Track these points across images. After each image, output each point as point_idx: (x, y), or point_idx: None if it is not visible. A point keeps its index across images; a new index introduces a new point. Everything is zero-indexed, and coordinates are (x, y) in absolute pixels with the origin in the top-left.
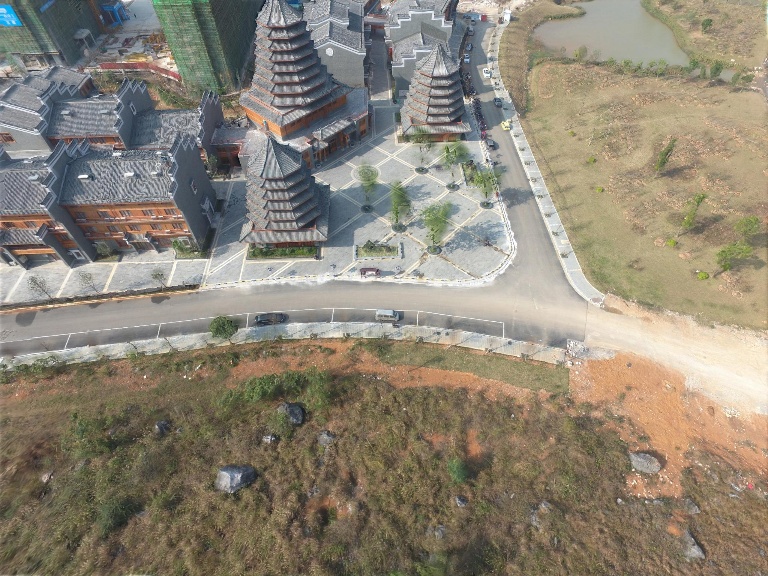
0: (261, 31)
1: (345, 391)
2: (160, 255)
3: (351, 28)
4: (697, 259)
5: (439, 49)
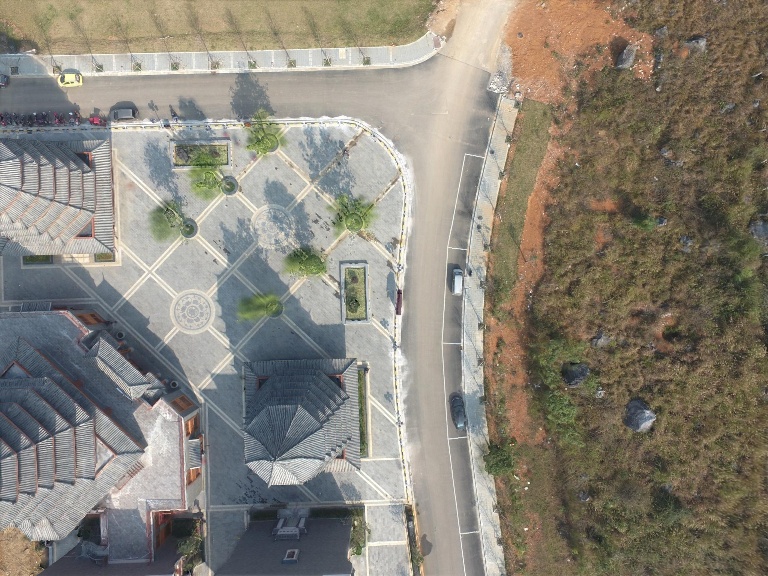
0: None
1: (552, 325)
2: (358, 568)
3: None
4: None
5: None
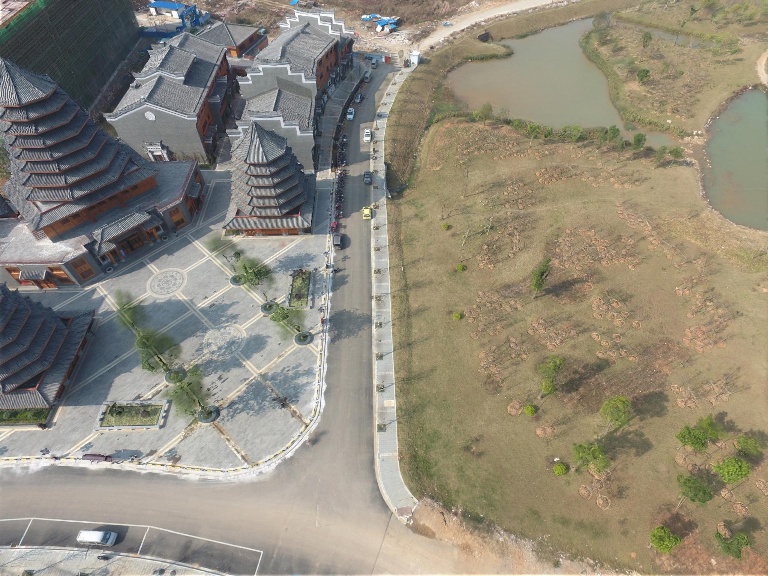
0: None
1: None
2: None
3: (192, 82)
4: (560, 437)
5: (253, 129)
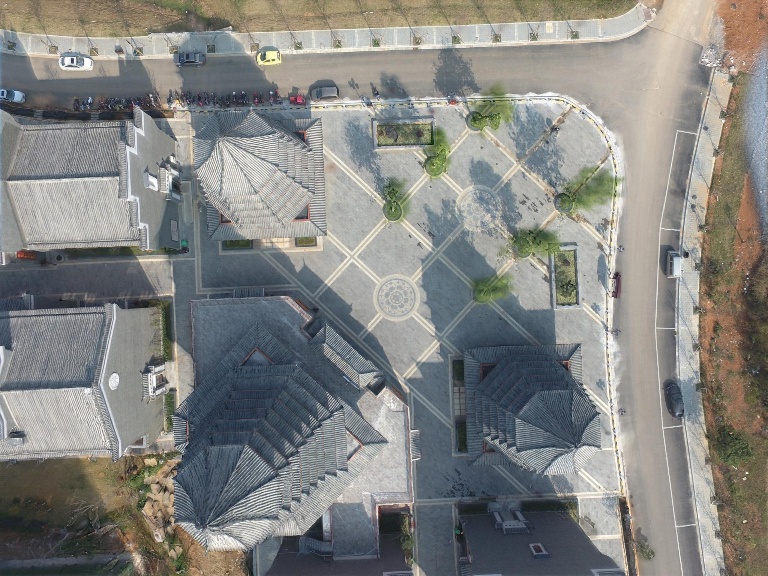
0: None
1: None
2: None
3: None
4: None
5: (231, 141)
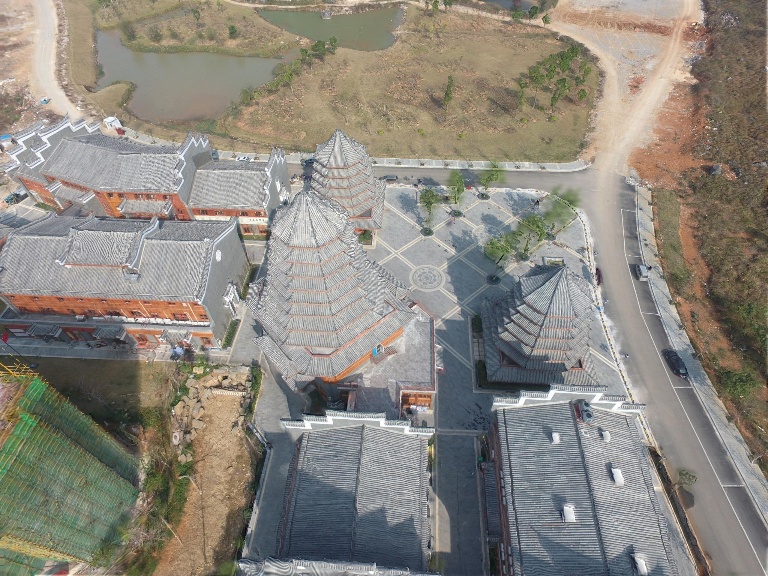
0: (327, 253)
1: (736, 301)
2: None
3: None
4: (536, 117)
5: (343, 133)
